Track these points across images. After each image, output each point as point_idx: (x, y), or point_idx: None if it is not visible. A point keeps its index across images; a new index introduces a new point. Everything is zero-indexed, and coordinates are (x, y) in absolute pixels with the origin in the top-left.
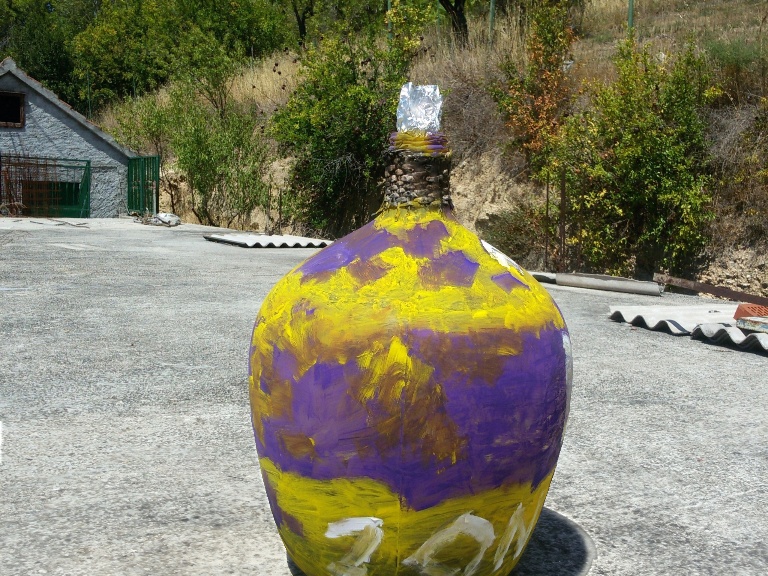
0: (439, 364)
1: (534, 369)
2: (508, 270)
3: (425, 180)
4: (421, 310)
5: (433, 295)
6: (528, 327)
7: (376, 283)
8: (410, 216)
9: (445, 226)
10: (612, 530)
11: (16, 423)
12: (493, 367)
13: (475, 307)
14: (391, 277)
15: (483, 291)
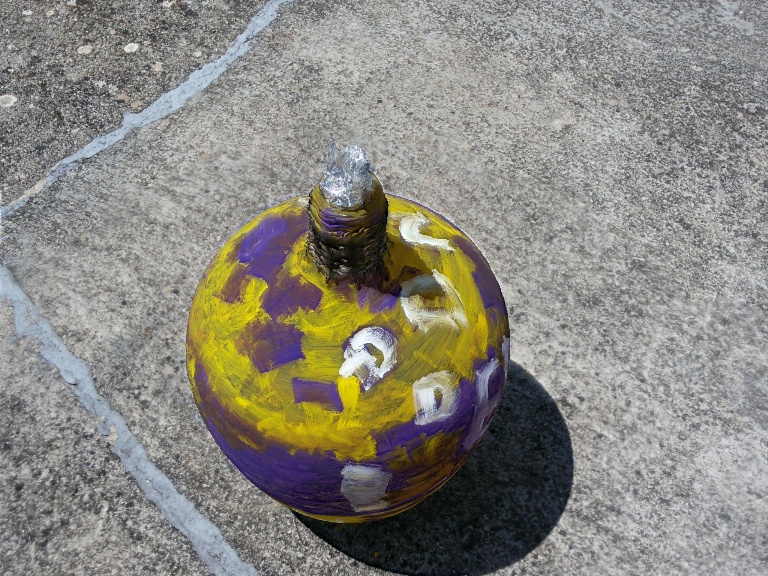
0: (204, 402)
1: (276, 468)
2: (339, 378)
3: (318, 243)
4: (215, 357)
5: (232, 353)
6: (283, 441)
7: (222, 303)
8: (304, 260)
9: (324, 294)
10: (553, 575)
11: (446, 37)
12: (234, 440)
13: (244, 392)
14: (231, 308)
15: (271, 384)
